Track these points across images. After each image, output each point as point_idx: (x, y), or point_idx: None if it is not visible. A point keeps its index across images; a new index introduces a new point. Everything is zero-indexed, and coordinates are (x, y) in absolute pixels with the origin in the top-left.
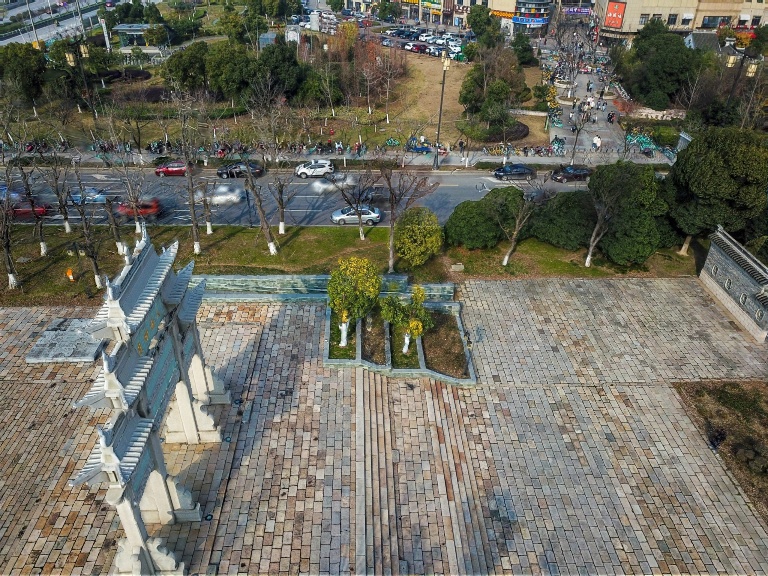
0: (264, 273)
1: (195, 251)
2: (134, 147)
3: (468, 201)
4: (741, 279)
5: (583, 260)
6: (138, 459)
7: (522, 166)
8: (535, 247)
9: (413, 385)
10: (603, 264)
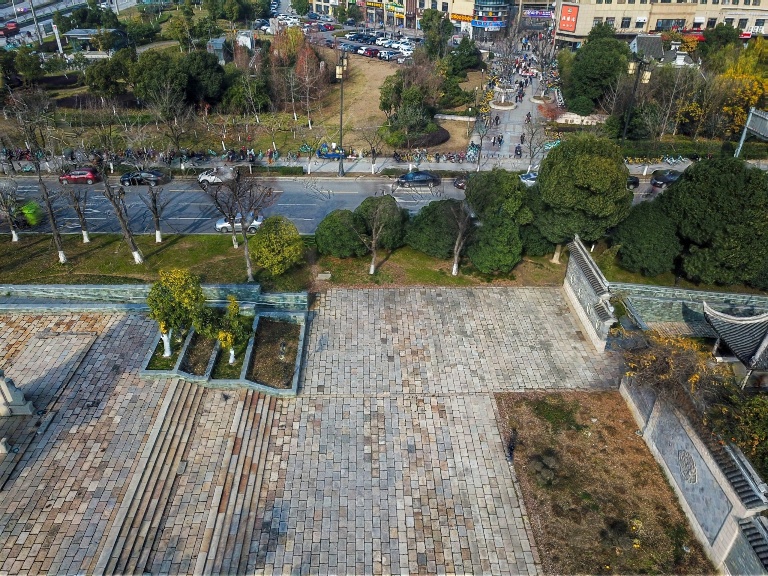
0: (121, 282)
1: (60, 260)
2: (4, 157)
3: (336, 210)
4: (587, 289)
5: None
6: None
7: (426, 173)
8: (408, 255)
9: (228, 396)
10: (471, 272)
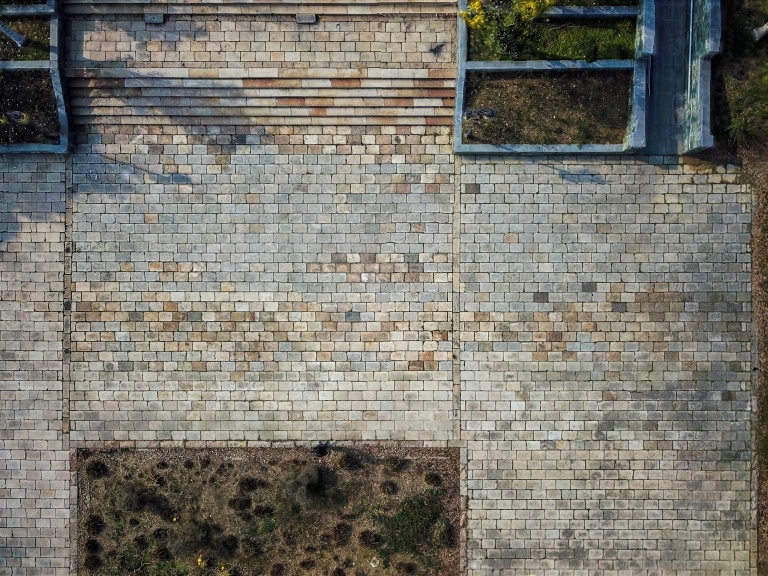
0: None
1: None
2: None
3: None
4: None
5: None
6: None
7: None
8: None
9: (440, 52)
10: None
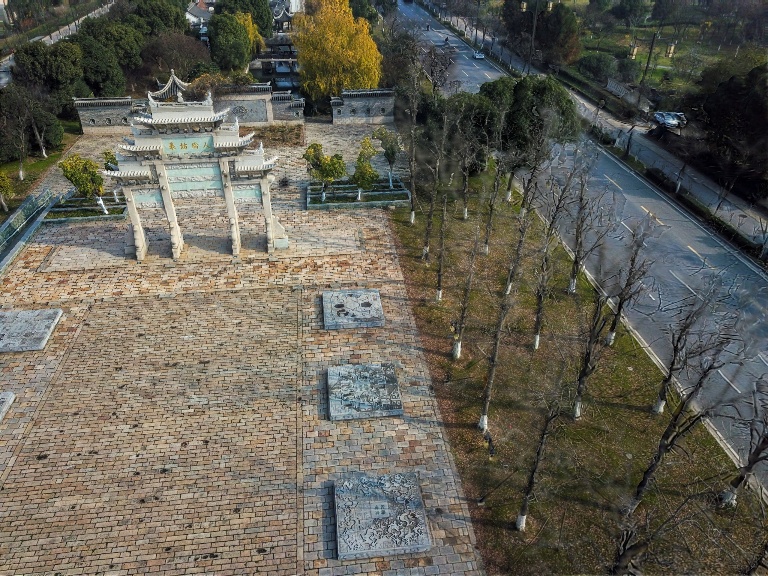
0: None
1: None
2: None
3: None
4: (115, 112)
5: (37, 158)
6: None
7: None
8: (7, 168)
9: None
10: (49, 153)
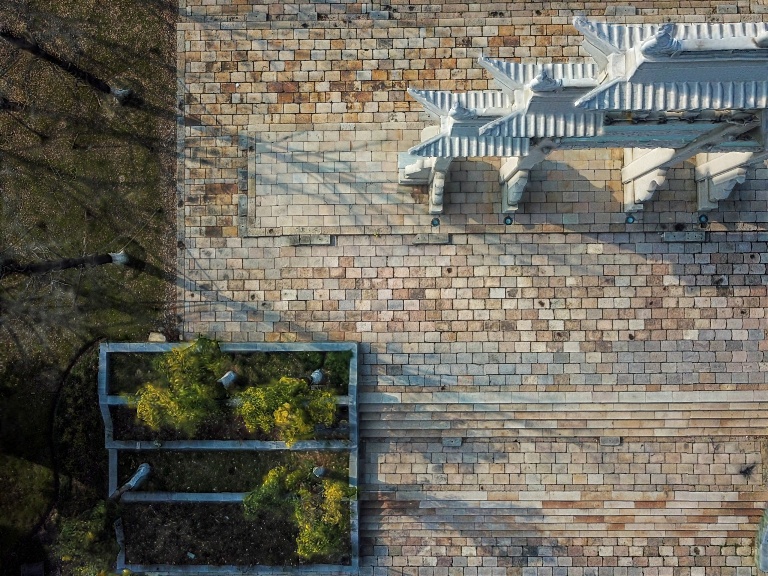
0: None
1: None
2: None
3: None
4: None
5: None
6: (456, 156)
7: None
8: None
9: (751, 475)
10: None
